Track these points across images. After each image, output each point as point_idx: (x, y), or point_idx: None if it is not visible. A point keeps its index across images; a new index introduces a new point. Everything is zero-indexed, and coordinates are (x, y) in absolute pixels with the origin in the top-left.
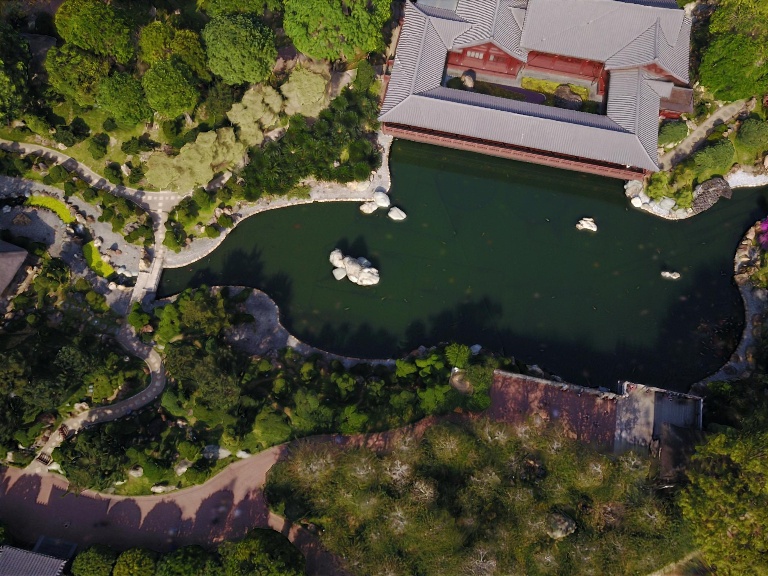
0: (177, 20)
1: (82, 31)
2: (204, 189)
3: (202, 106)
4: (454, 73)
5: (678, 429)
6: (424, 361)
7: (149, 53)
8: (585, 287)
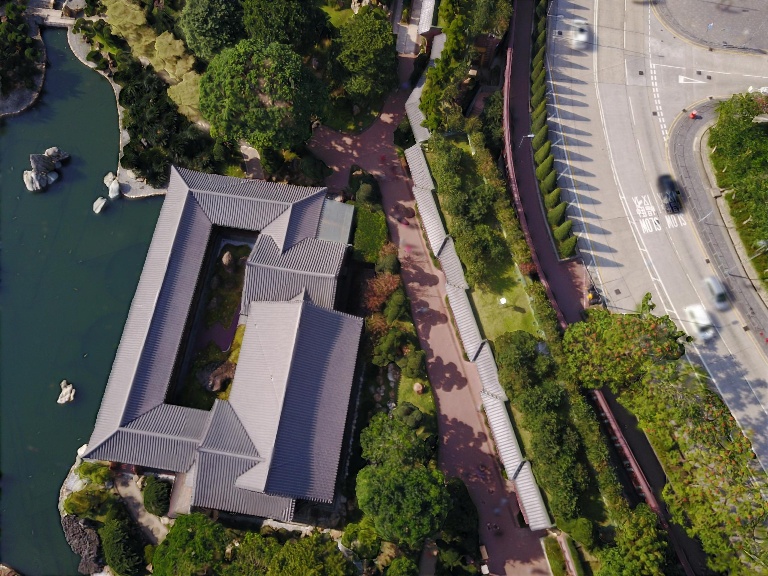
0: None
1: None
2: None
3: None
4: None
5: None
6: None
7: None
8: (3, 390)
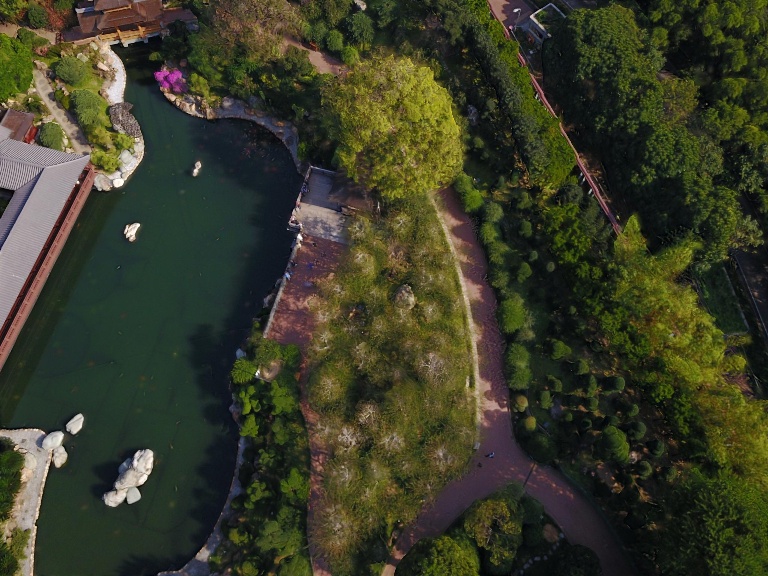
0: None
1: None
2: None
3: None
4: None
5: (333, 189)
6: (245, 406)
7: None
8: (195, 244)
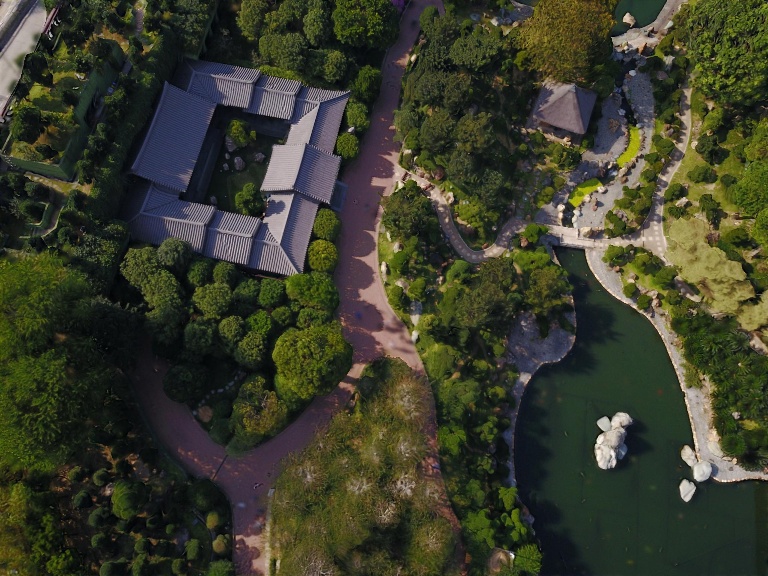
0: None
1: None
2: None
3: None
4: None
5: None
6: (518, 518)
7: None
8: None
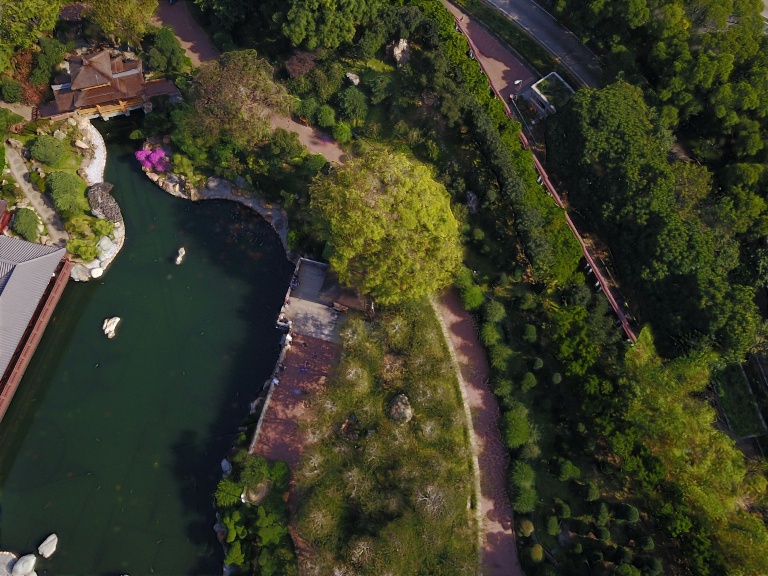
0: None
1: None
2: None
3: None
4: None
5: (324, 287)
6: (229, 532)
7: None
8: (179, 339)
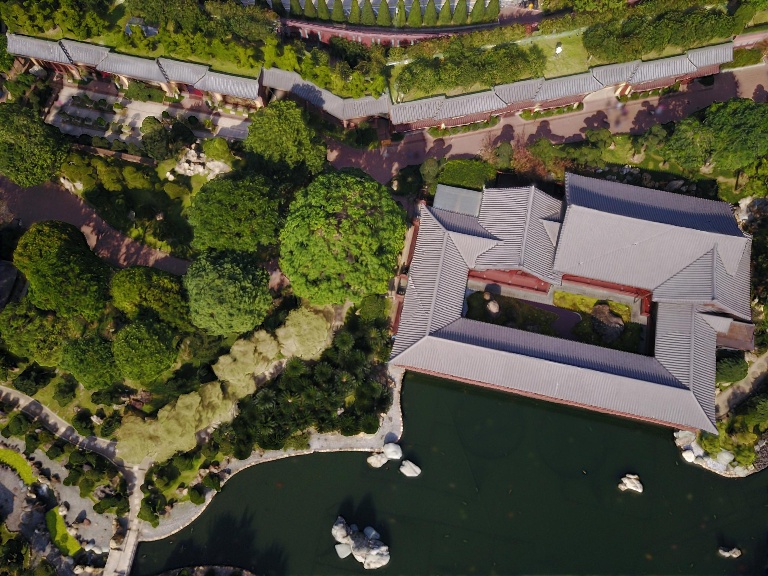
0: (159, 229)
1: (40, 296)
2: (186, 454)
3: (185, 342)
4: (476, 286)
5: None
6: None
7: (122, 302)
8: (629, 563)
